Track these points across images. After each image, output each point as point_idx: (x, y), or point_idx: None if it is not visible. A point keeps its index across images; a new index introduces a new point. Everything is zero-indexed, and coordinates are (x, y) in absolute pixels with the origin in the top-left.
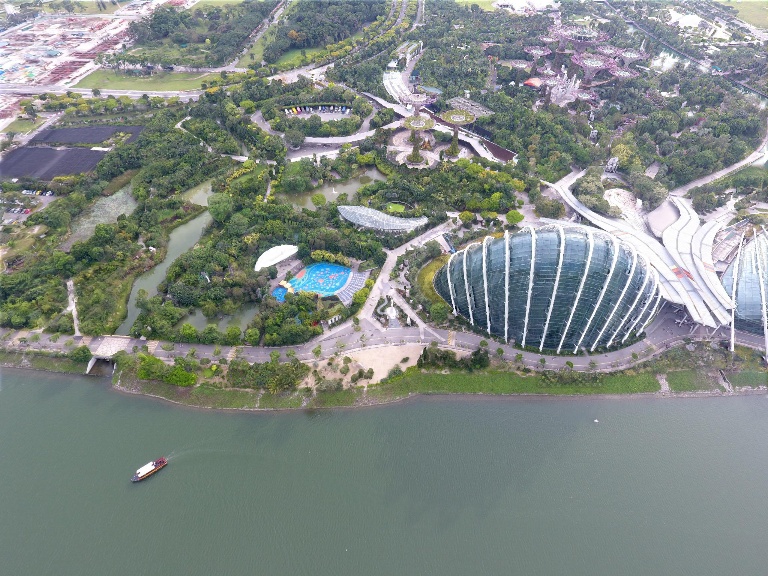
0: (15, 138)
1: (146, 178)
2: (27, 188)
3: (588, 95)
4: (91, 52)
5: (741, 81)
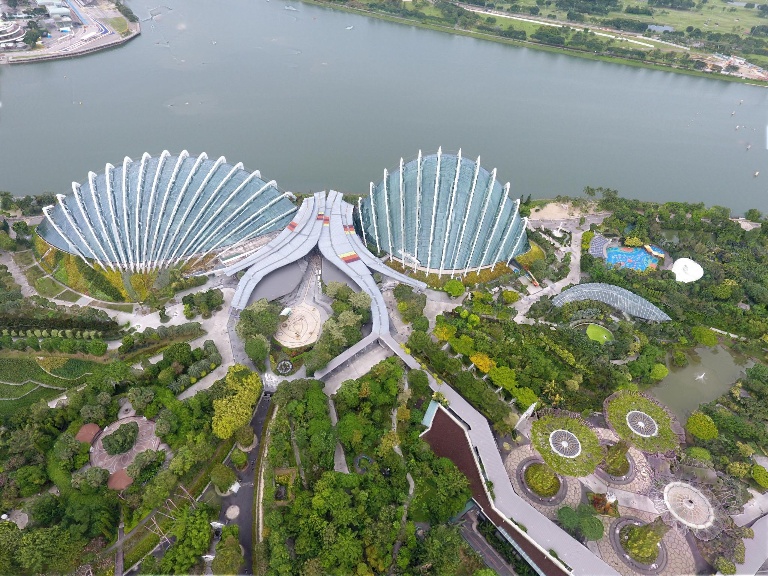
0: None
1: None
2: None
3: None
4: None
5: None
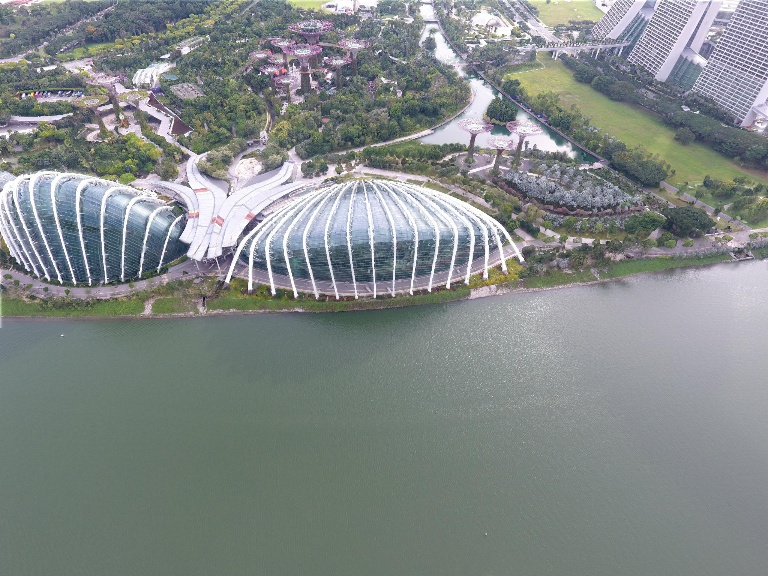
0: None
1: None
2: None
3: (289, 80)
4: None
5: (481, 71)
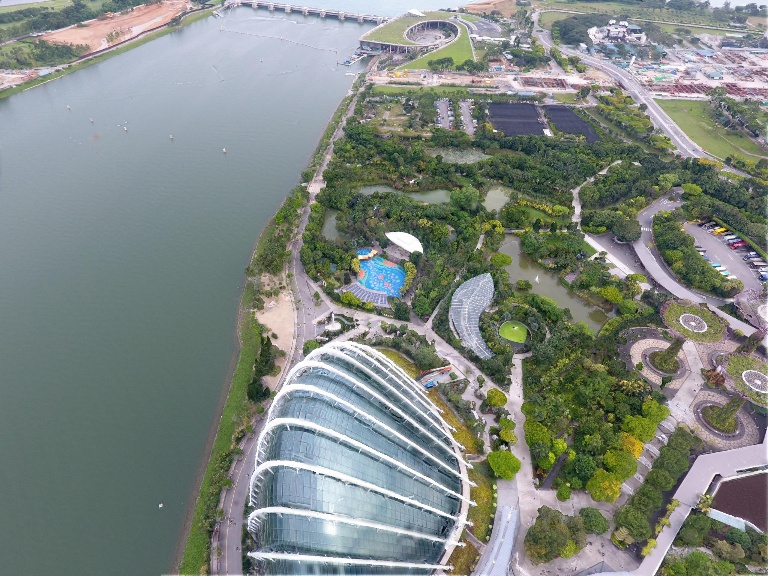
0: (549, 100)
1: (507, 160)
2: (478, 120)
3: None
4: (744, 90)
5: None
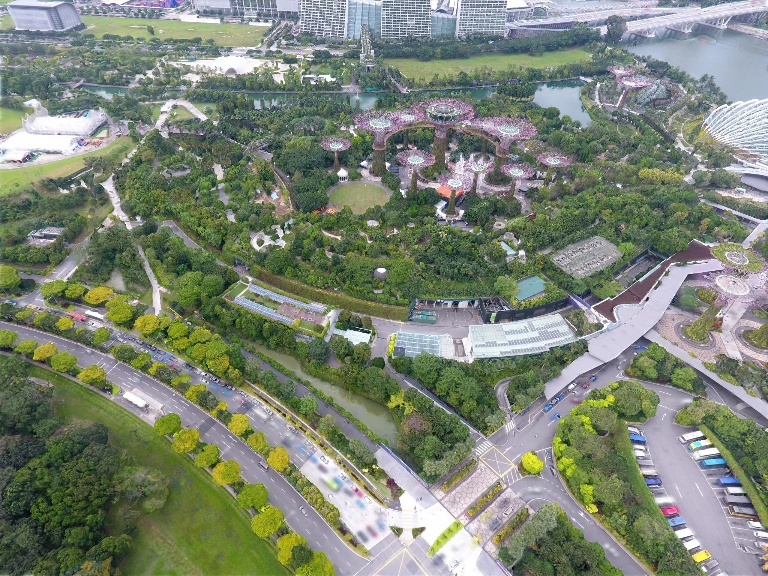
0: None
1: None
2: None
3: (553, 158)
4: None
5: None
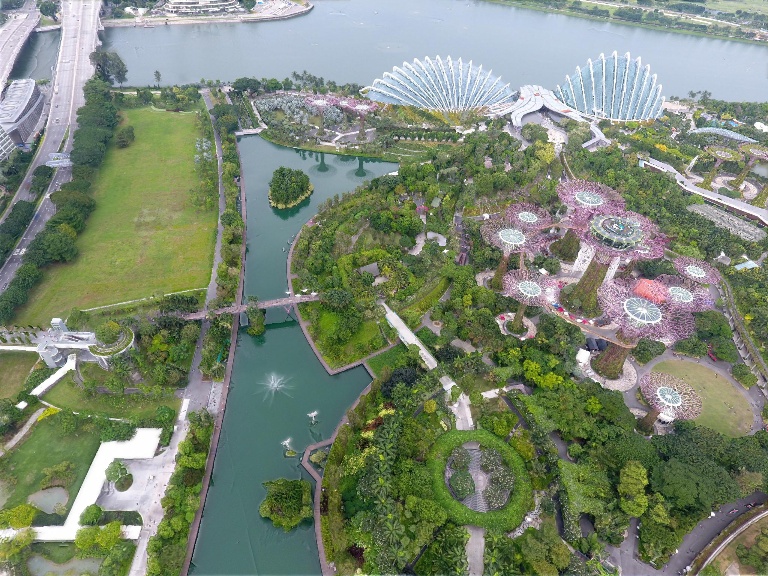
0: None
1: None
2: None
3: None
4: None
5: None
